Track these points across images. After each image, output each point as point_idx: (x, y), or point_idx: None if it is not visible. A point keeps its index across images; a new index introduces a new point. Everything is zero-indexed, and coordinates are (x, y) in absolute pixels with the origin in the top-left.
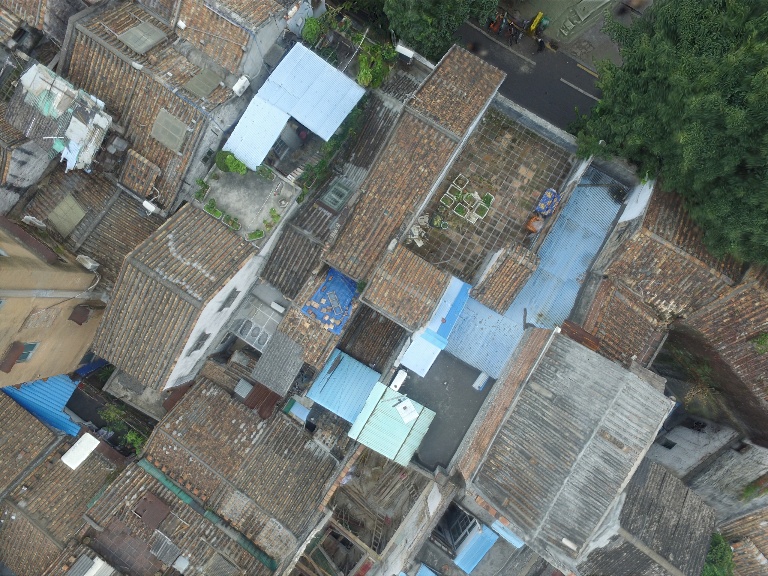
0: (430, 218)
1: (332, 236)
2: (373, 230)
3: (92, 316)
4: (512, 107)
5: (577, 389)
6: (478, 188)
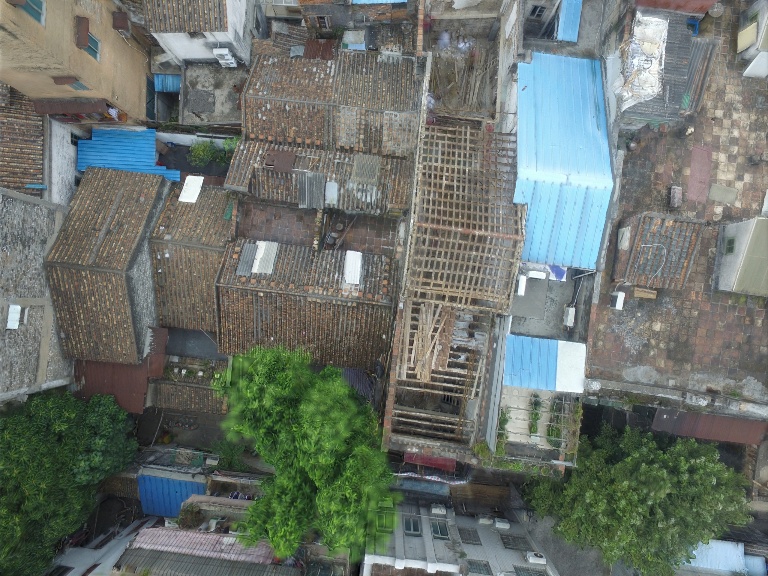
0: None
1: None
2: None
3: (132, 46)
4: None
5: None
6: None
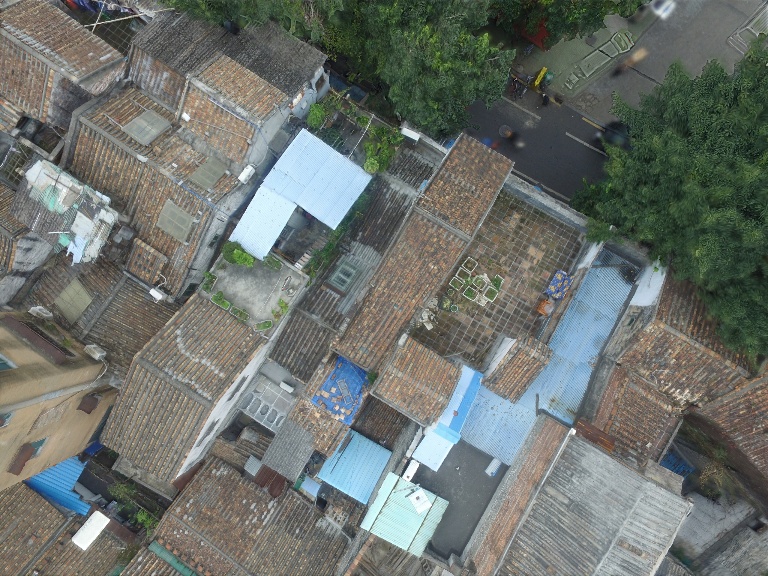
0: (439, 301)
1: (341, 330)
2: (383, 323)
3: None
4: (520, 189)
5: (594, 495)
6: (487, 270)
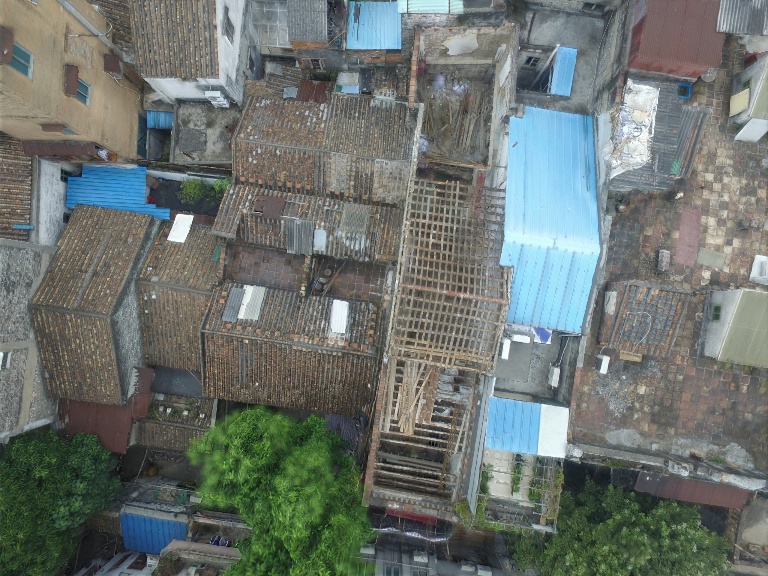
0: None
1: None
2: None
3: (124, 85)
4: None
5: None
6: None
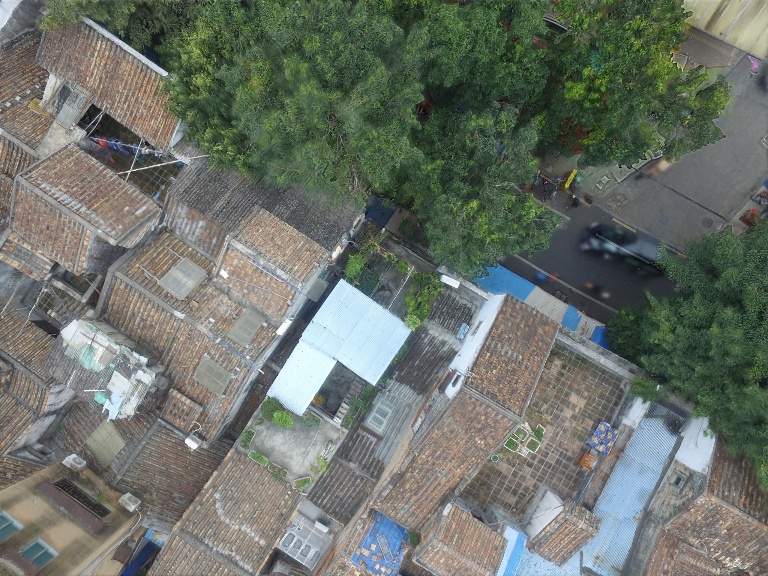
0: None
1: (384, 495)
2: (426, 488)
3: None
4: (563, 340)
5: None
6: (528, 418)
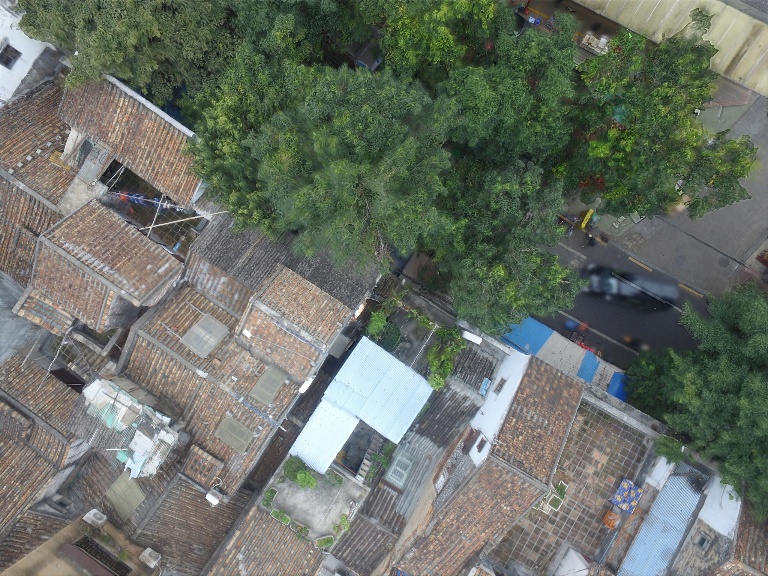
0: None
1: (407, 557)
2: (450, 550)
3: None
4: (586, 398)
5: None
6: None
